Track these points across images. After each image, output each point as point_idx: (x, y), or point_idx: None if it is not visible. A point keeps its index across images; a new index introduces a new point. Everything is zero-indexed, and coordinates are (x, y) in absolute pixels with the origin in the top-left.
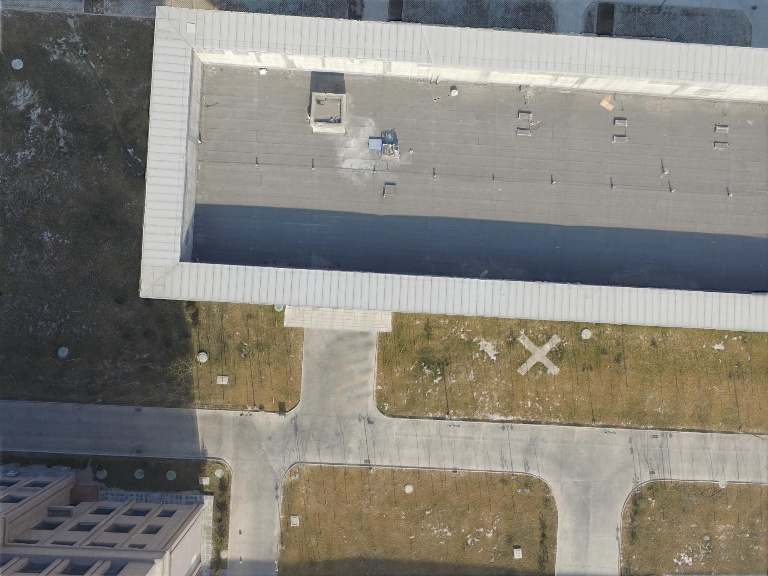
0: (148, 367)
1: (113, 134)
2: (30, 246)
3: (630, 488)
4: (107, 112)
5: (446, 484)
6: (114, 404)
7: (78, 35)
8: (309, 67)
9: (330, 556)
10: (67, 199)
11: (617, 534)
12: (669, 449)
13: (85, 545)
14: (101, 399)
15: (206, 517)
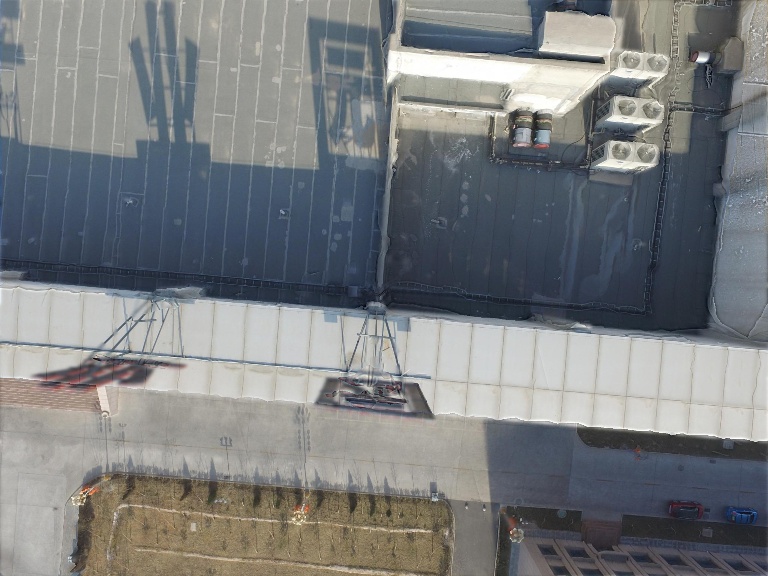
0: None
1: None
2: None
3: None
4: None
5: None
6: None
7: None
8: None
9: None
10: None
11: None
12: None
13: None
14: None
15: None
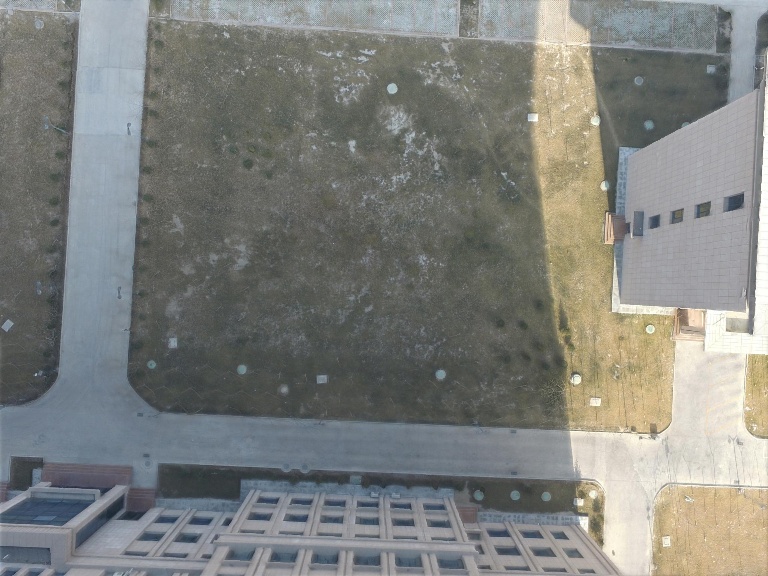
0: (522, 389)
1: (487, 158)
2: (406, 269)
3: None
4: (480, 136)
5: None
6: (490, 426)
7: (453, 59)
8: None
9: (699, 575)
10: (441, 222)
11: None
12: None
13: (544, 571)
14: (477, 421)
15: None
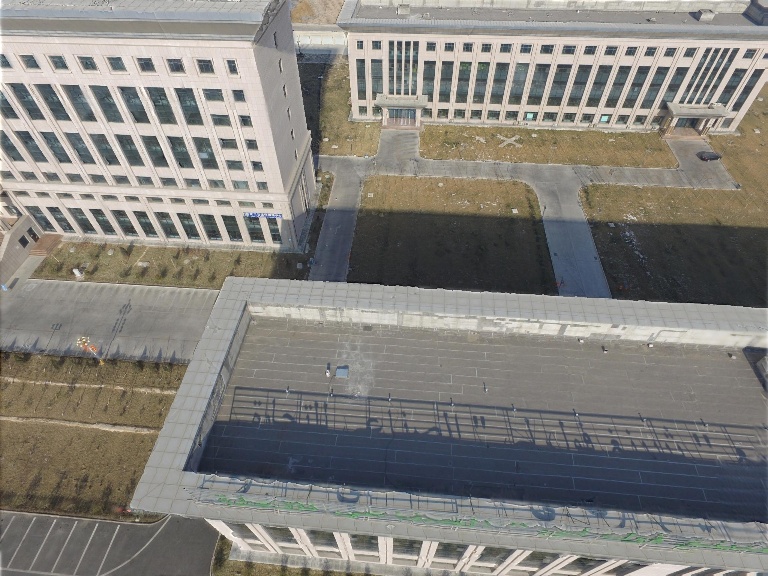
0: None
1: None
2: None
3: (580, 186)
4: None
5: (463, 183)
6: None
7: None
8: (397, 4)
9: (392, 211)
10: None
11: (579, 204)
12: (599, 173)
13: None
14: None
15: (317, 191)
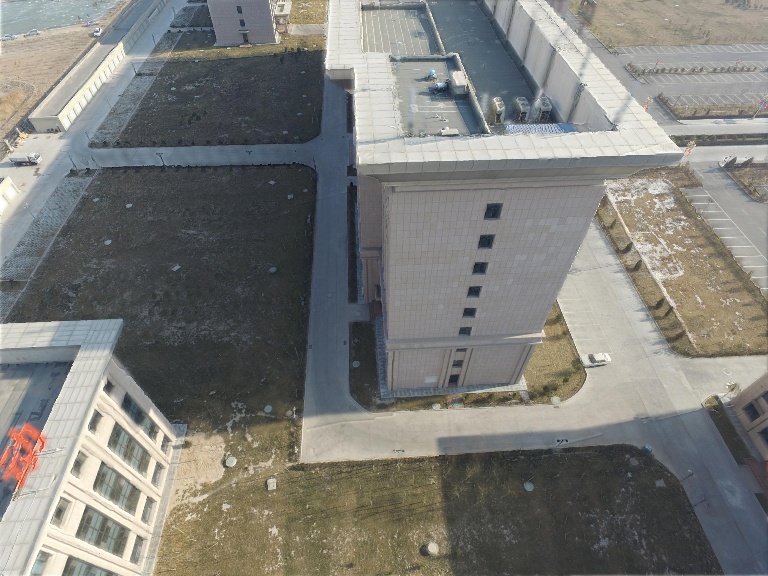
0: None
1: None
2: None
3: None
4: None
5: None
6: None
7: None
8: None
9: None
10: None
11: None
12: None
13: None
14: None
15: None
